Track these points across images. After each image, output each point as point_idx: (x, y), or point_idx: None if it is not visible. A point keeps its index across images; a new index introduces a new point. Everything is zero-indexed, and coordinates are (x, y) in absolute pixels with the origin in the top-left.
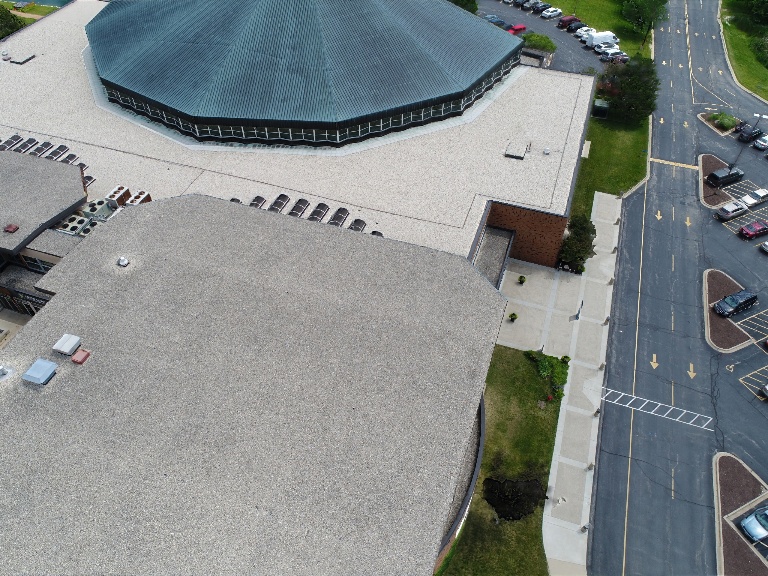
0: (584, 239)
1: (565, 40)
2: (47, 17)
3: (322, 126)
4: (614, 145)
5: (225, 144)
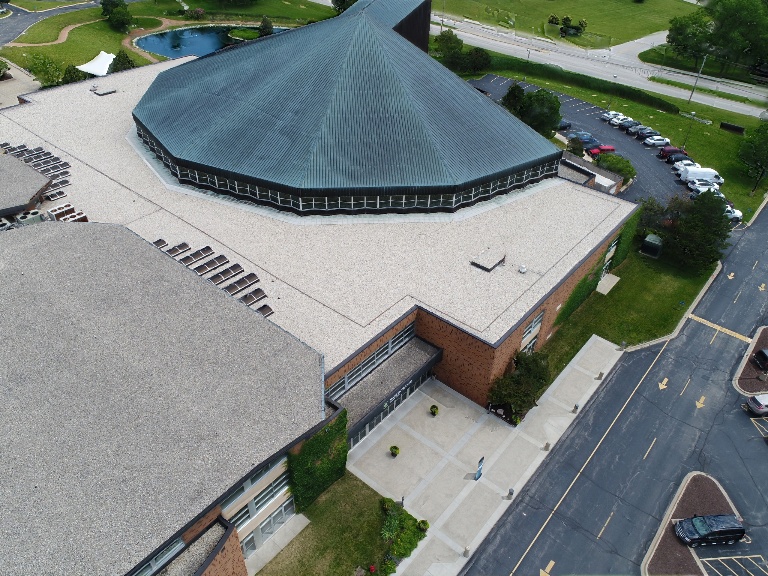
0: (523, 382)
1: (658, 170)
2: (152, 65)
3: (285, 190)
4: (649, 289)
5: (200, 190)
